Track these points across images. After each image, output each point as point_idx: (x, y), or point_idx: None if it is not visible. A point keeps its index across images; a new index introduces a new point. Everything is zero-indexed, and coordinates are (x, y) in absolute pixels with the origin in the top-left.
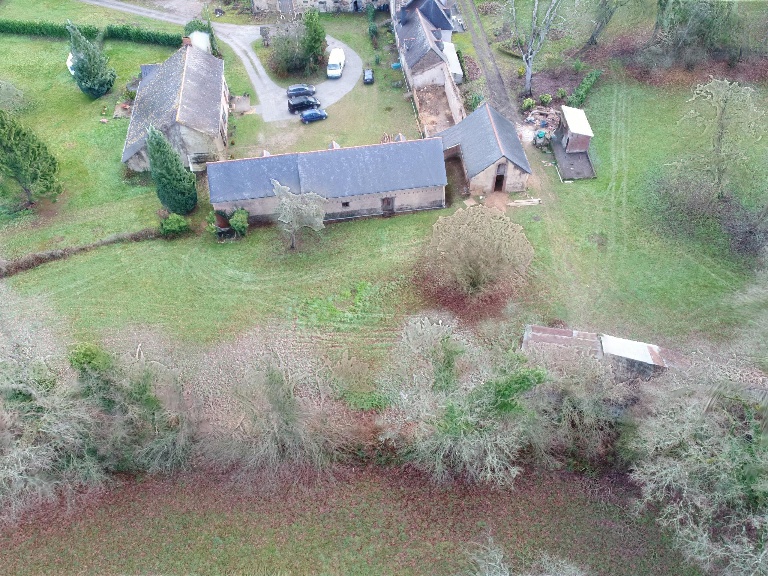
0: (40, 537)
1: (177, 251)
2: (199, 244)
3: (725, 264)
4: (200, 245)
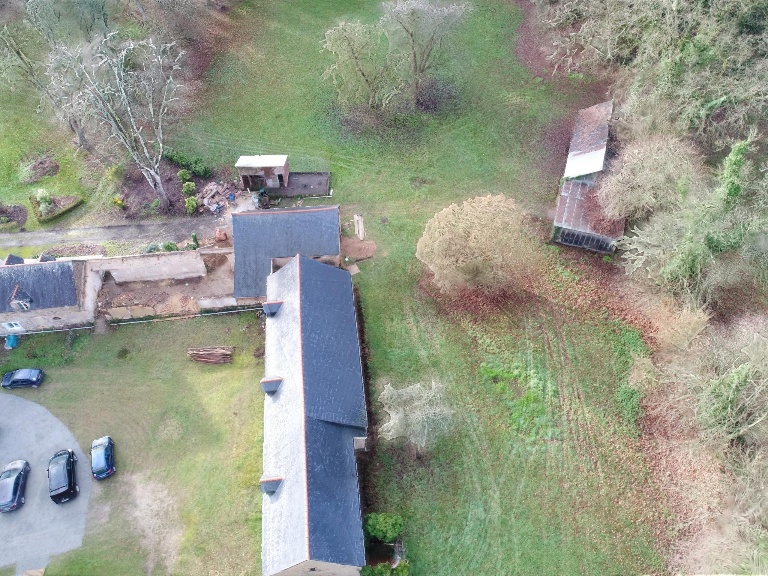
0: None
1: None
2: None
3: (450, 120)
4: None
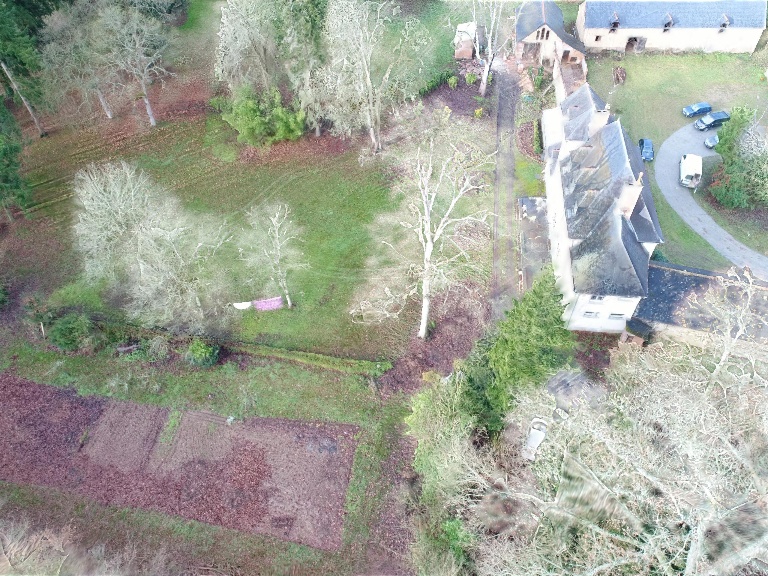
0: None
1: None
2: None
3: None
4: None
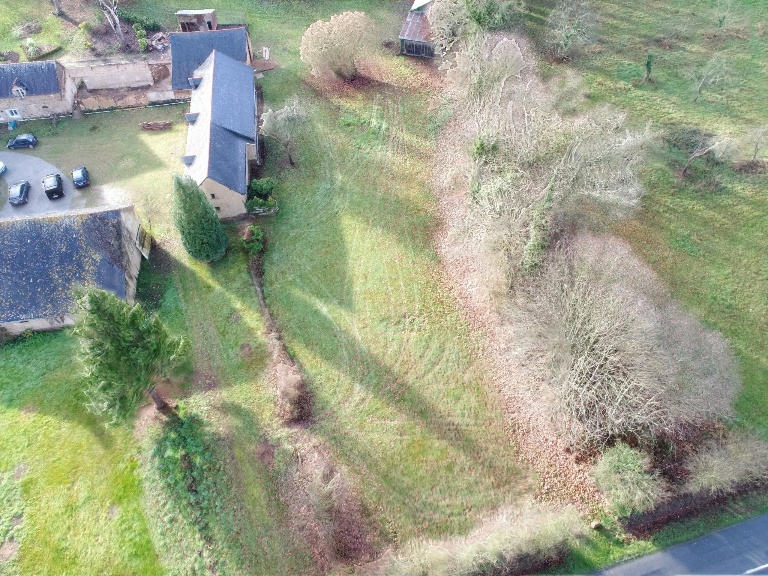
0: (578, 239)
1: (284, 240)
2: (276, 226)
3: None
4: (278, 225)
